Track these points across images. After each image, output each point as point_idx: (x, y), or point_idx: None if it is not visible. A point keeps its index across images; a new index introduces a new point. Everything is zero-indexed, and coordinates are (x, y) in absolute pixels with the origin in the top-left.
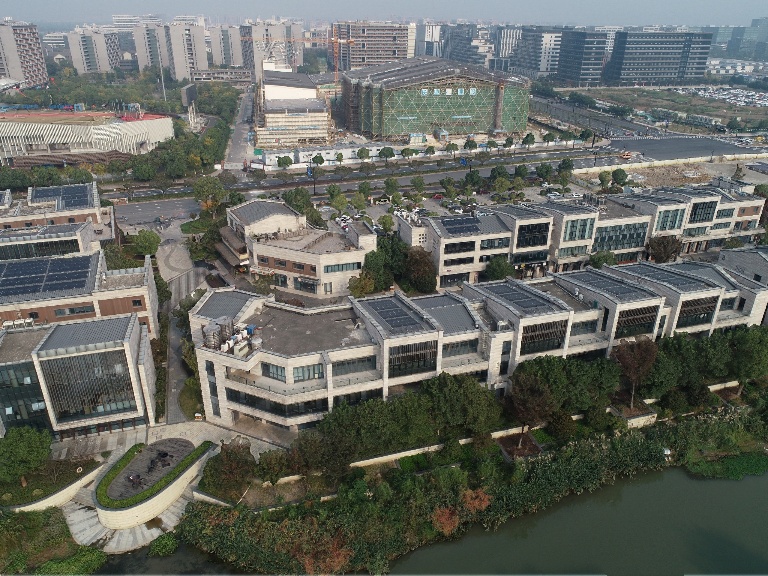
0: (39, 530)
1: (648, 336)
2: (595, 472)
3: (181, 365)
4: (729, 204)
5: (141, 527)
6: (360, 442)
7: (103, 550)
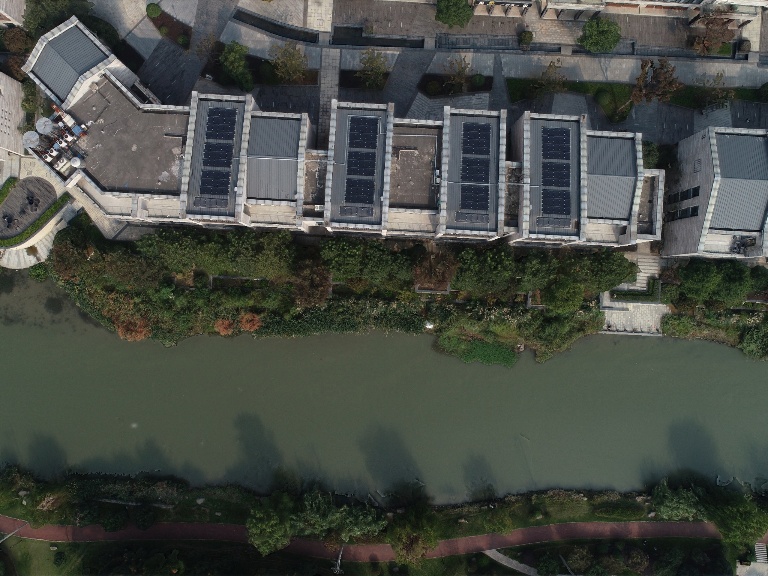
0: None
1: (484, 238)
2: (355, 327)
3: None
4: None
5: (23, 251)
6: None
7: None
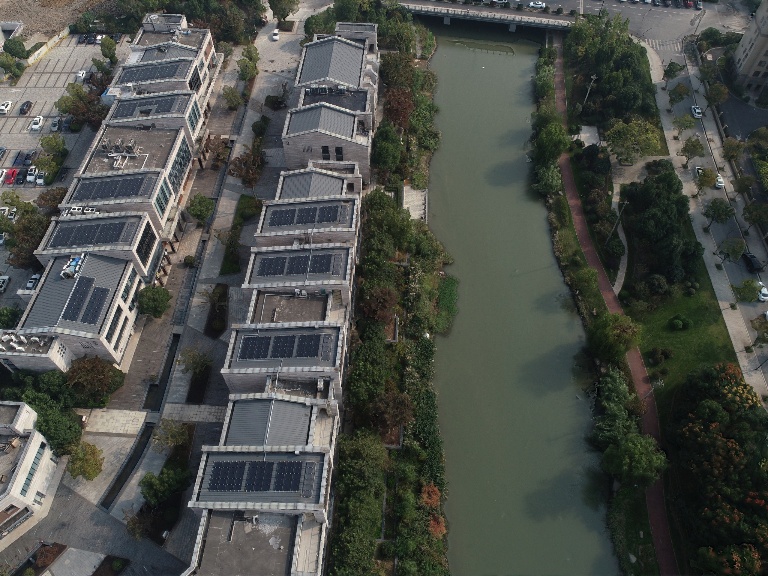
0: None
1: None
2: (431, 395)
3: None
4: (198, 58)
5: None
6: (370, 571)
7: None
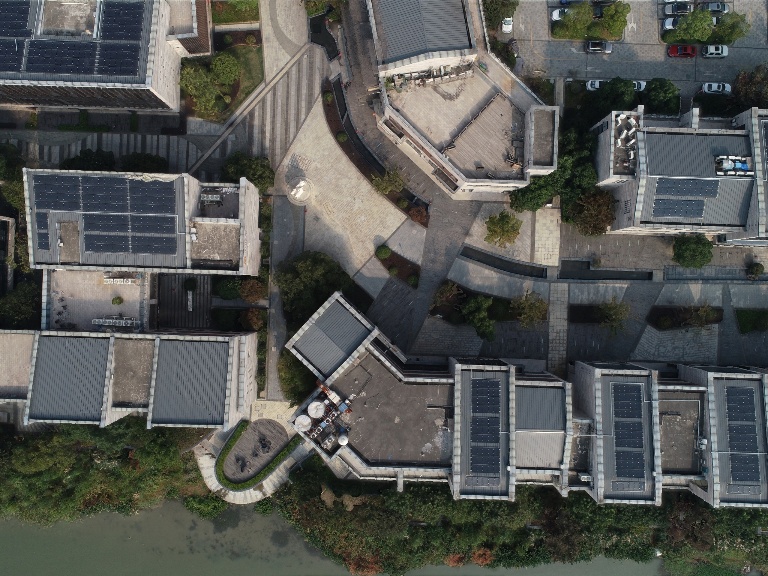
0: (181, 474)
1: None
2: (585, 558)
3: (282, 306)
4: None
5: None
6: None
7: (225, 500)
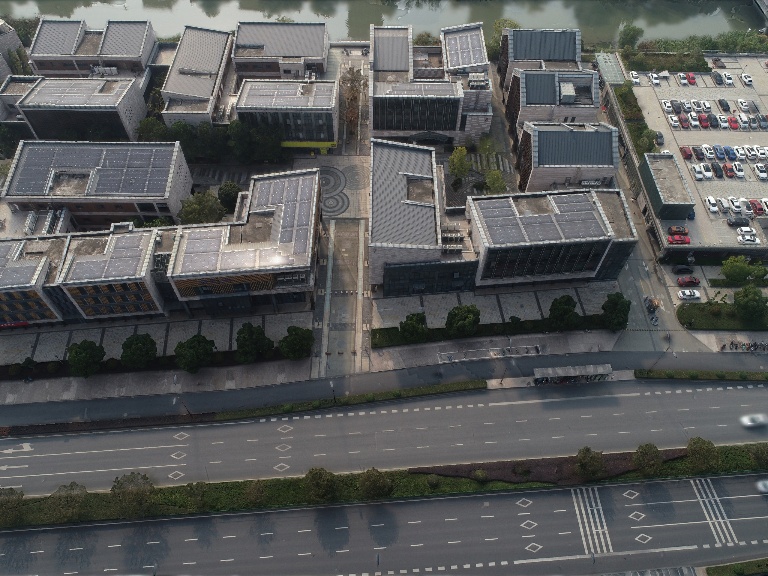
0: None
1: None
2: None
3: None
4: None
5: None
6: None
7: None
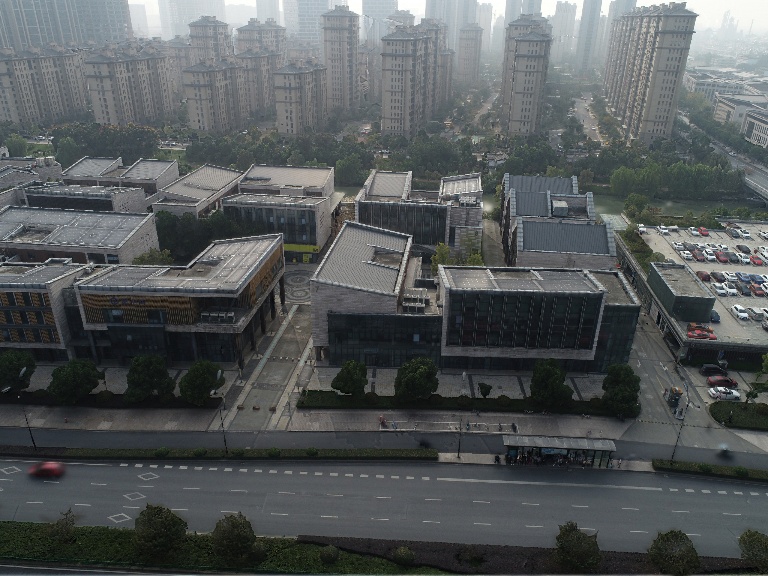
0: None
1: None
2: None
3: None
4: None
5: None
6: None
7: None
